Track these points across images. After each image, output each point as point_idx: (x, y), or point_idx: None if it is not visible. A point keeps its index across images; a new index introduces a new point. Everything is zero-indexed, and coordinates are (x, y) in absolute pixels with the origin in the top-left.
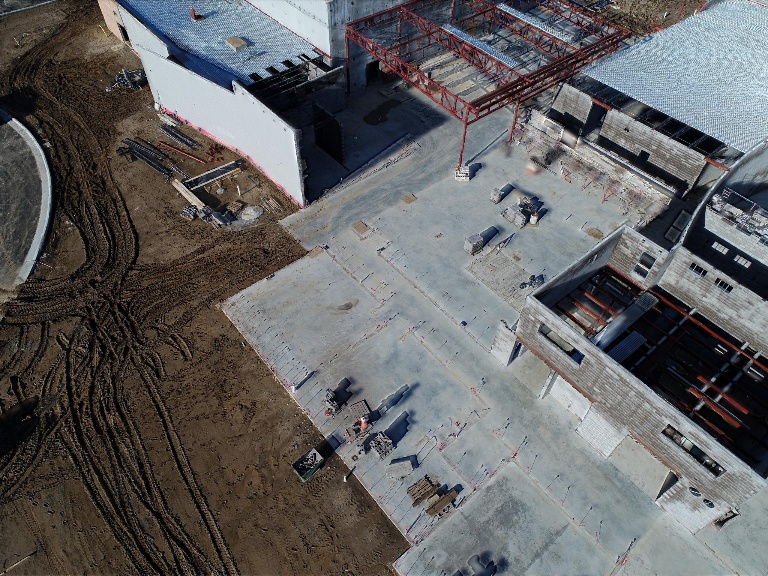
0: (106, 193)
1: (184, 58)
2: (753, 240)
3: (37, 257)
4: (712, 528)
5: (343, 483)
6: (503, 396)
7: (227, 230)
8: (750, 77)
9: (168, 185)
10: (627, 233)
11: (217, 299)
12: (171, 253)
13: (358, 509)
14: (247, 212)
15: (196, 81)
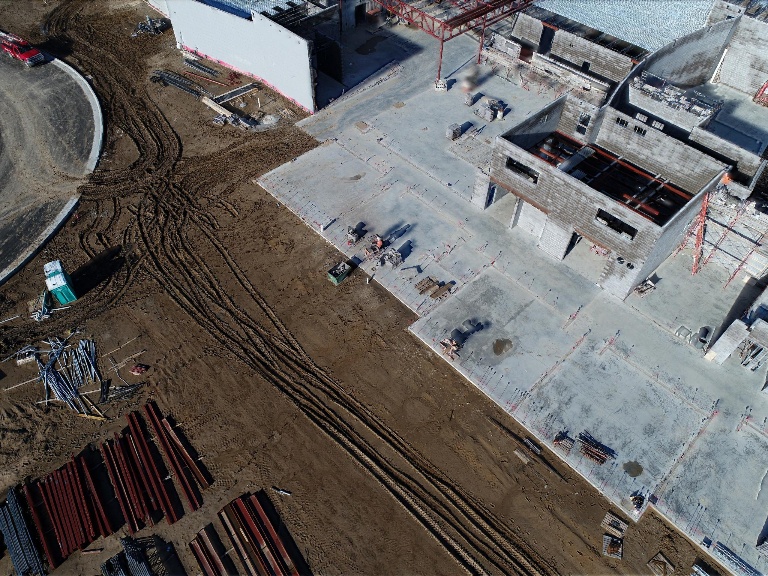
0: (147, 110)
1: (202, 2)
2: (664, 105)
3: (99, 155)
4: (637, 297)
5: (366, 285)
6: (482, 228)
7: (253, 131)
8: (669, 5)
9: (198, 102)
10: (569, 99)
11: (252, 177)
12: (209, 149)
13: (379, 299)
14: (268, 118)
15: (218, 15)
